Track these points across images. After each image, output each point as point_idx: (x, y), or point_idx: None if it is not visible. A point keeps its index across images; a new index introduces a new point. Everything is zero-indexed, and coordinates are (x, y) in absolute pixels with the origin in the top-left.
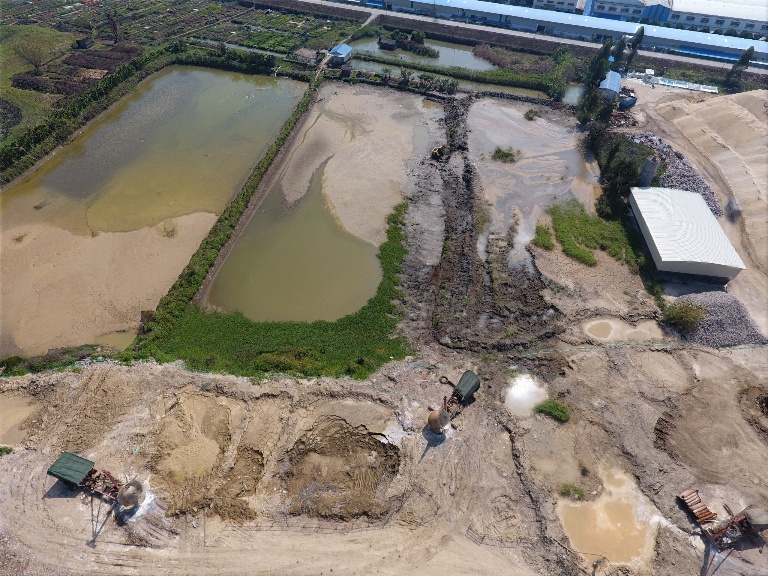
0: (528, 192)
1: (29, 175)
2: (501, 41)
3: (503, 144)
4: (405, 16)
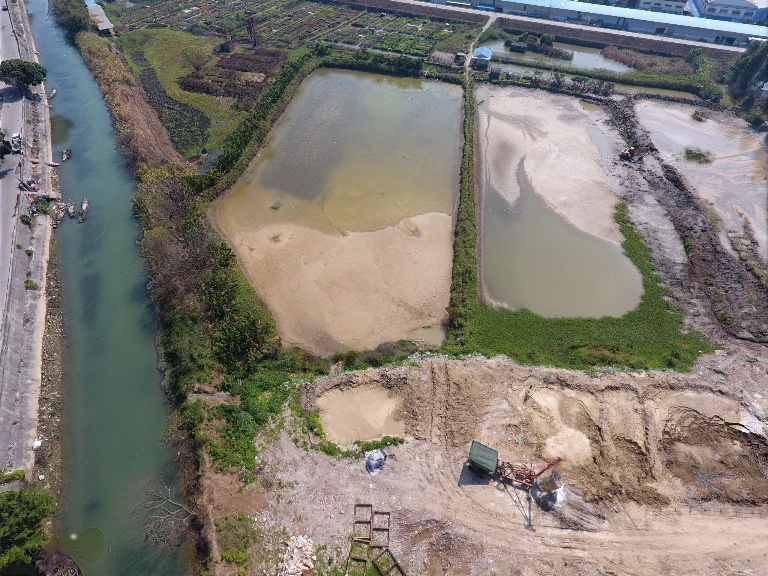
0: (740, 192)
1: (247, 176)
2: (628, 43)
3: (688, 145)
4: (524, 19)
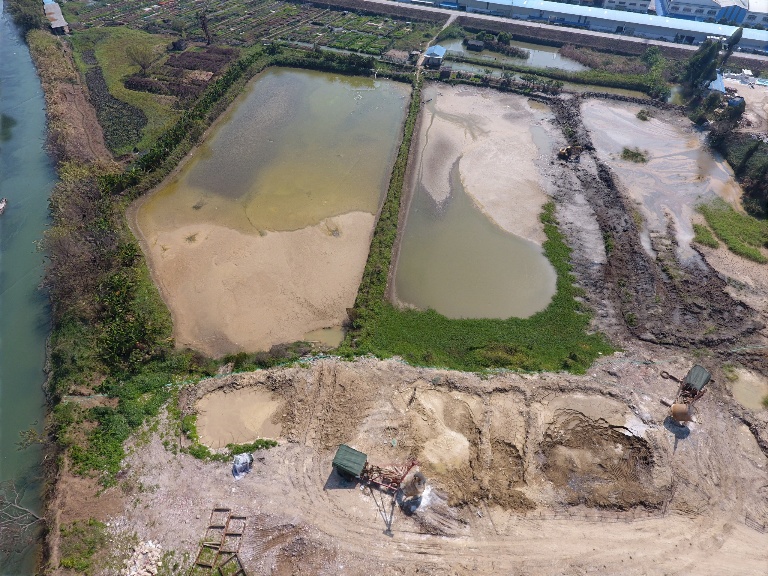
0: (671, 191)
1: (175, 175)
2: (586, 42)
3: (627, 144)
4: (485, 17)
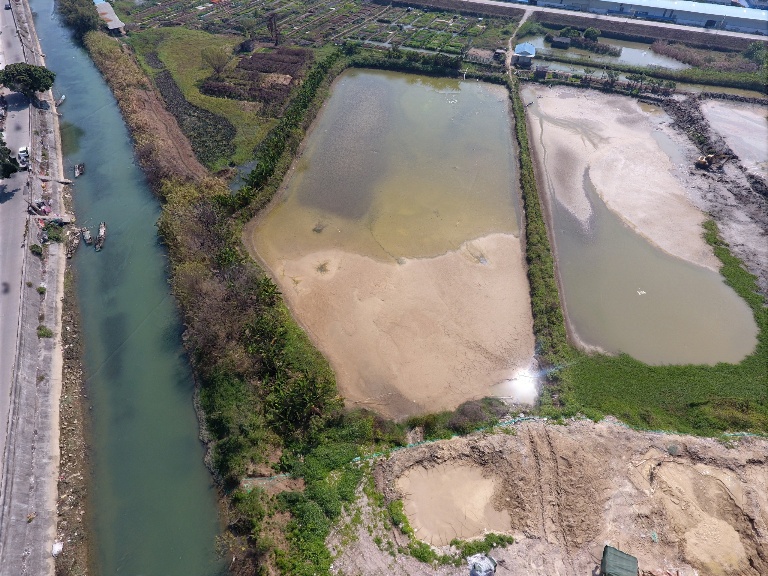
0: None
1: (283, 193)
2: (679, 37)
3: None
4: (563, 12)
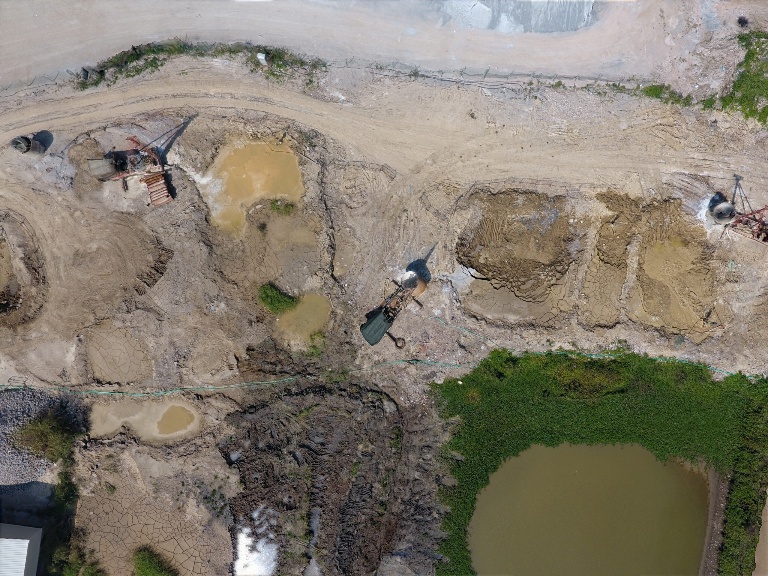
0: None
1: None
2: None
3: None
4: None
